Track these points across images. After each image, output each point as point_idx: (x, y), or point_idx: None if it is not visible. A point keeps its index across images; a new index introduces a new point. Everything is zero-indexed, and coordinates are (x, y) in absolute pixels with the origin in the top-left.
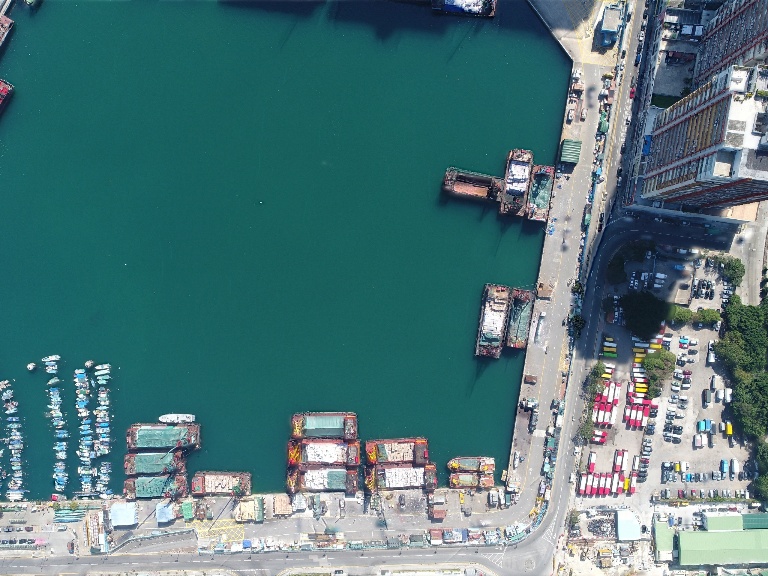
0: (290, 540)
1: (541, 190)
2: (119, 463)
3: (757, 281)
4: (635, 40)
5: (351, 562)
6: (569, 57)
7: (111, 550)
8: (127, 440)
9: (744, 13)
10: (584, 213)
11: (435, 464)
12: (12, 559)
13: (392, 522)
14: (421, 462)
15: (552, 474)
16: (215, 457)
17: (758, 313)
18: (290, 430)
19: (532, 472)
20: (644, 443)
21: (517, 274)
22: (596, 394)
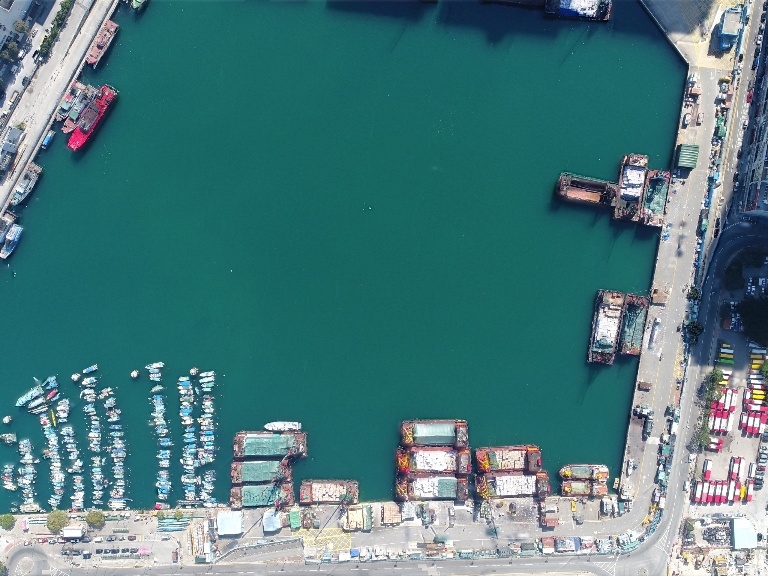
0: (398, 549)
1: (656, 195)
2: (223, 471)
3: None
4: (752, 44)
5: (461, 571)
6: (684, 61)
7: (216, 559)
8: (234, 448)
9: None
10: (700, 218)
11: (546, 472)
12: (114, 568)
13: (502, 530)
14: (534, 470)
15: (667, 482)
16: (321, 465)
17: None
18: (398, 438)
19: (645, 480)
20: (761, 450)
21: (630, 280)
22: (713, 401)
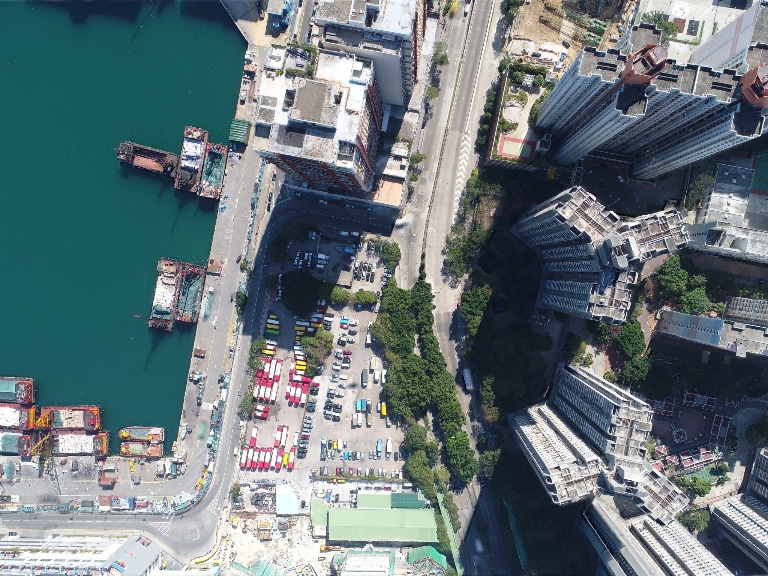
0: None
1: (215, 168)
2: None
3: (416, 266)
4: (307, 25)
5: (25, 525)
6: (245, 39)
7: None
8: None
9: None
10: None
11: (107, 432)
12: None
13: (65, 487)
14: (89, 429)
15: (215, 446)
16: None
17: (404, 296)
18: None
19: (199, 444)
20: (304, 420)
21: (191, 249)
22: (257, 369)
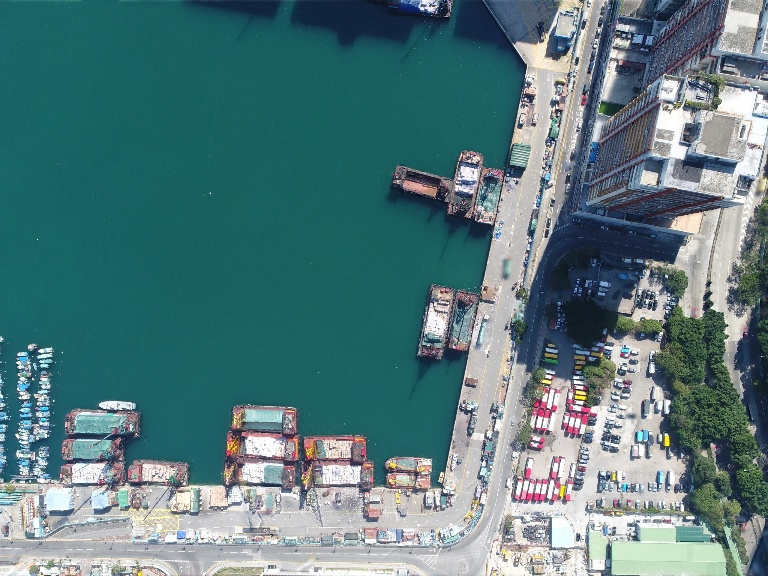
0: (225, 533)
1: (490, 193)
2: (58, 448)
3: (701, 294)
4: (589, 47)
5: (285, 557)
6: (523, 61)
7: (45, 535)
8: (65, 425)
9: (686, 24)
10: (531, 218)
11: (373, 463)
12: None
13: (327, 519)
14: (358, 460)
15: (488, 478)
16: (154, 446)
17: (698, 325)
18: (230, 422)
19: (469, 475)
20: (581, 451)
21: (462, 276)
22: (535, 400)
